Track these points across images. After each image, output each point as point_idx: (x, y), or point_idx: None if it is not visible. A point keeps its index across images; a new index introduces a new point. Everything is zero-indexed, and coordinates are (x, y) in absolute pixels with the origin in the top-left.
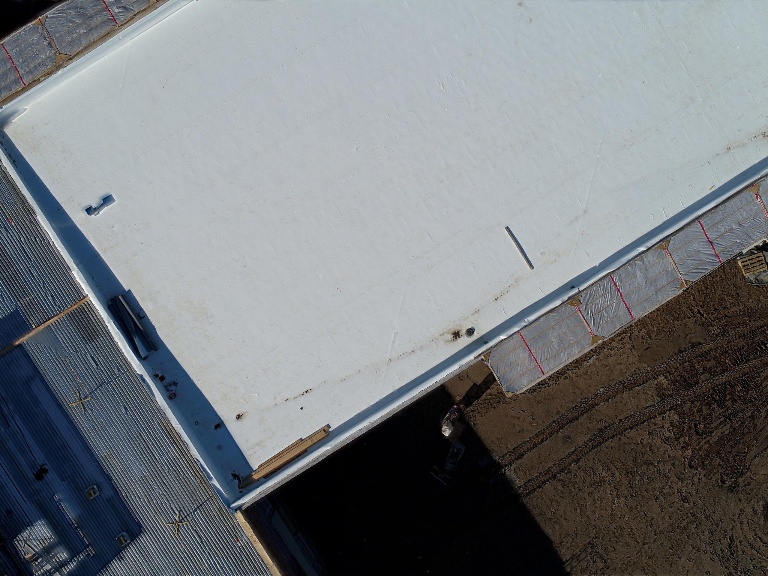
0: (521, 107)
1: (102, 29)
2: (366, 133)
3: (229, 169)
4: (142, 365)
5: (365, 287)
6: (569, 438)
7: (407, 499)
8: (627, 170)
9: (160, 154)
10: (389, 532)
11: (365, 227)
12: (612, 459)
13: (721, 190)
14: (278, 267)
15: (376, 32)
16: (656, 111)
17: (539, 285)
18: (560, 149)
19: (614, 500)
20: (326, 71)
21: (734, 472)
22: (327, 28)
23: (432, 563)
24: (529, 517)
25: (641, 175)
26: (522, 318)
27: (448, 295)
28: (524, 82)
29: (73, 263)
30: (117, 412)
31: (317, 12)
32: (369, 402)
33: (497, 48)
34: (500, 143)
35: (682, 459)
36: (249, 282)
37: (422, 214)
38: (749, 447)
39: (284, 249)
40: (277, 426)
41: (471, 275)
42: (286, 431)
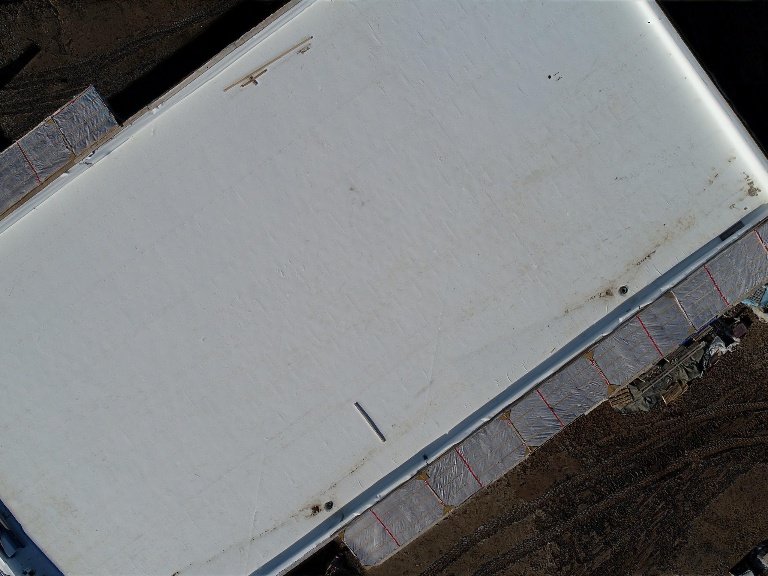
0: (360, 287)
1: None
2: (211, 324)
3: (80, 368)
4: (8, 566)
5: (222, 471)
6: (453, 575)
7: None
8: (469, 339)
9: (12, 359)
10: None
11: (218, 413)
12: None
13: (562, 353)
14: (136, 458)
15: (213, 226)
16: (493, 281)
17: (392, 456)
18: (402, 324)
19: None
20: (167, 268)
21: None
22: (164, 227)
23: None
24: None
25: (483, 343)
26: (375, 492)
27: (304, 472)
28: (361, 263)
29: None
30: None
31: (154, 212)
32: None
33: (332, 233)
34: (343, 323)
35: None
36: (109, 475)
37: (272, 397)
38: (631, 571)
39: (140, 441)
40: None
41: (325, 451)
42: None
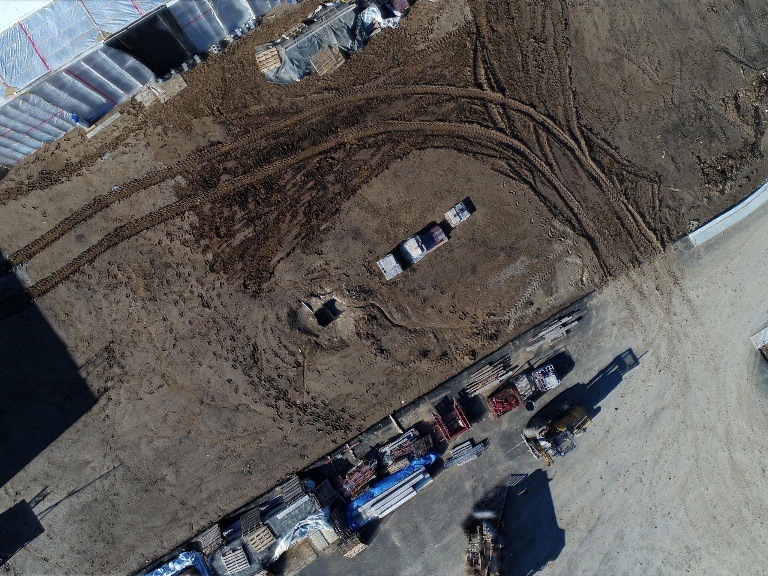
0: None
1: None
2: None
3: None
4: None
5: None
6: (82, 237)
7: None
8: None
9: None
10: None
11: None
12: (129, 260)
13: None
14: None
15: None
16: None
17: None
18: None
19: (131, 303)
20: None
21: (258, 277)
22: None
23: None
24: (42, 319)
25: None
26: None
27: None
28: None
29: None
30: None
31: None
32: None
33: None
34: None
35: (203, 262)
36: None
37: None
38: (273, 252)
39: None
40: None
41: None
42: None
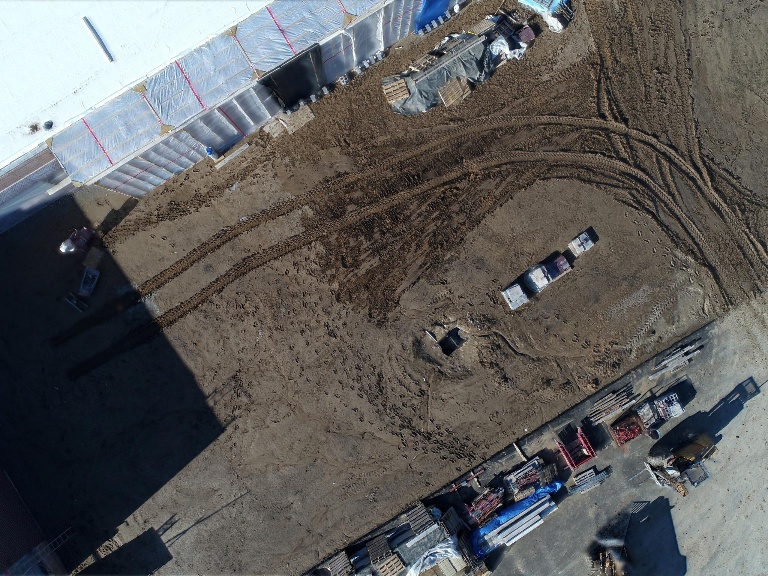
0: None
1: None
2: None
3: None
4: None
5: None
6: (211, 267)
7: (43, 327)
8: None
9: None
10: (25, 361)
11: None
12: (256, 290)
13: None
14: None
15: None
16: None
17: (119, 78)
18: None
19: (258, 332)
20: None
21: (383, 306)
22: None
23: (69, 394)
24: (170, 348)
25: None
26: None
27: (25, 86)
28: None
29: None
30: None
31: None
32: None
33: None
34: None
35: (329, 292)
36: None
37: None
38: (398, 281)
39: None
40: None
41: (48, 66)
42: None
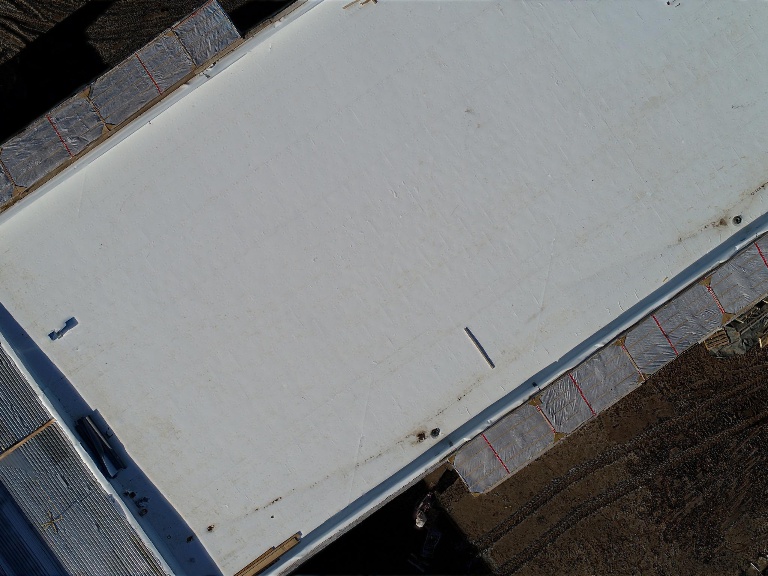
0: (474, 210)
1: (56, 160)
2: (323, 244)
3: (189, 286)
4: (111, 485)
5: (329, 394)
6: (544, 518)
7: None
8: (581, 266)
9: (120, 275)
10: None
11: (326, 335)
12: (587, 537)
13: (674, 281)
14: (242, 379)
15: (327, 145)
16: (606, 207)
17: (501, 383)
18: (514, 249)
19: None
20: (280, 185)
21: (709, 543)
22: (279, 144)
23: None
24: None
25: (595, 270)
26: (485, 418)
27: (412, 398)
28: (475, 186)
29: (38, 388)
30: (89, 530)
31: (268, 129)
32: (339, 507)
33: (447, 154)
34: (455, 246)
35: (657, 533)
36: (214, 395)
37: (382, 320)
38: (722, 517)
39: (247, 361)
40: (249, 536)
41: (433, 377)
42: (258, 540)
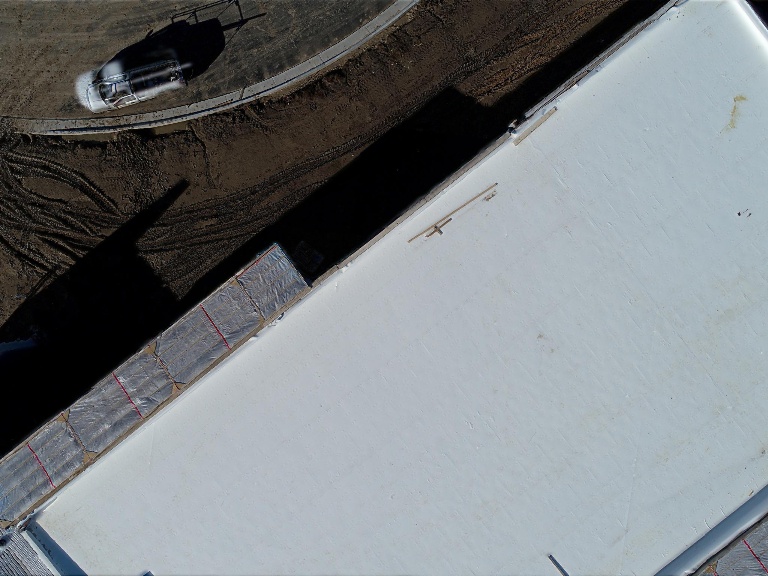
0: (552, 437)
1: (127, 424)
2: (399, 480)
3: (266, 532)
4: None
5: None
6: None
7: None
8: (664, 485)
9: (195, 525)
10: None
11: (408, 573)
12: None
13: (761, 496)
14: None
15: (399, 380)
16: (687, 424)
17: None
18: (595, 473)
19: None
20: (353, 424)
21: None
22: (350, 383)
23: None
24: None
25: (679, 489)
26: None
27: None
28: (552, 412)
29: None
30: None
31: (338, 368)
32: None
33: (522, 381)
34: (535, 474)
35: None
36: None
37: (464, 553)
38: None
39: None
40: None
41: None
42: None
